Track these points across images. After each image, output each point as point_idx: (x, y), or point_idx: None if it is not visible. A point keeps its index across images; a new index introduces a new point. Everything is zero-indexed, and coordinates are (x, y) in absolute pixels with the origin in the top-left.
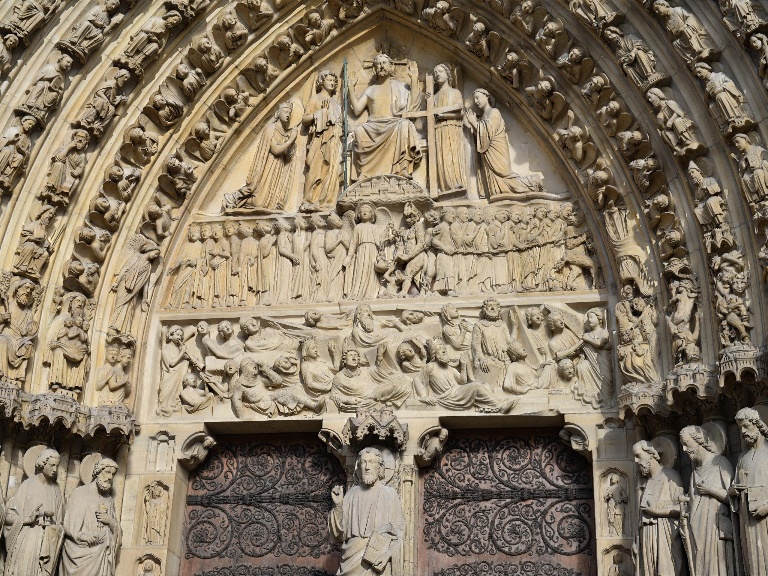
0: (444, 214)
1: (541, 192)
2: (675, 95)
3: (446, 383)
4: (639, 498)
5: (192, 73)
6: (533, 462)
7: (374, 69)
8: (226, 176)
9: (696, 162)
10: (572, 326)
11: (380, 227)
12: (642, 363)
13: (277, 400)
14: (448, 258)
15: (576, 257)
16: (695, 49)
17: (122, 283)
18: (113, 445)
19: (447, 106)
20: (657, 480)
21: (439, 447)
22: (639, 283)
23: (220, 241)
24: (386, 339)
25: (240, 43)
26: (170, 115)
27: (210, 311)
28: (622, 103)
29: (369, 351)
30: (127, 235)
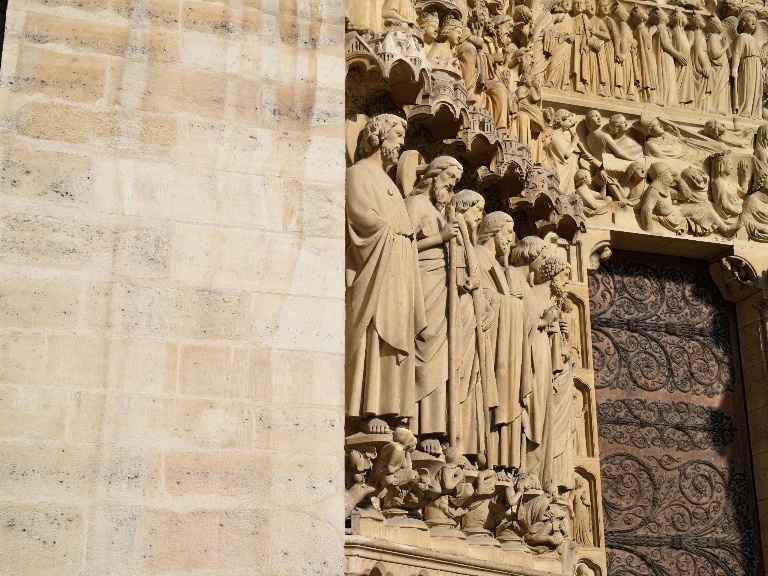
0: None
1: None
2: None
3: None
4: None
5: None
6: None
7: None
8: None
9: None
10: None
11: None
12: None
13: (691, 216)
14: None
15: None
16: None
17: (538, 45)
18: None
19: None
20: None
21: None
22: None
23: (595, 19)
24: None
25: None
26: None
27: (599, 100)
28: None
29: None
30: None
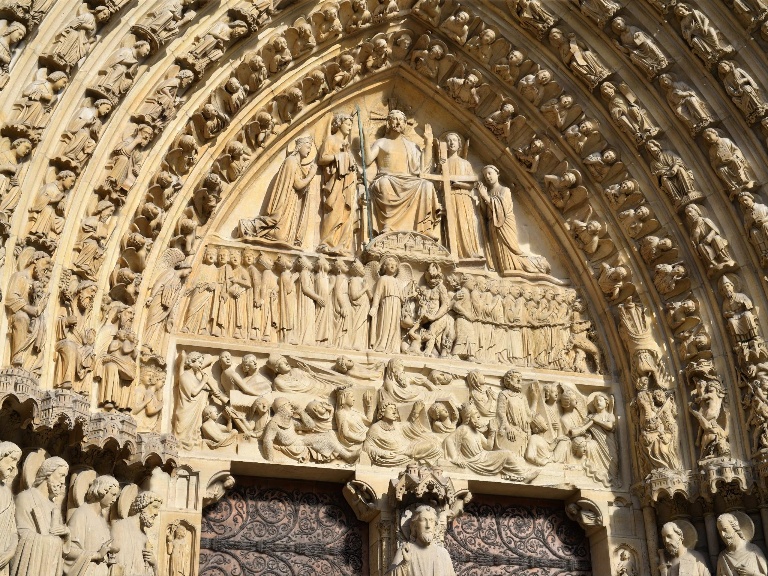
0: (465, 280)
1: (549, 275)
2: (708, 214)
3: (477, 447)
4: (666, 575)
5: (241, 89)
6: (537, 531)
7: (388, 123)
8: (239, 200)
9: (726, 277)
10: (579, 406)
11: (400, 282)
12: (668, 451)
13: (311, 446)
14: (470, 324)
15: (584, 342)
16: (742, 179)
17: (157, 298)
18: (138, 476)
19: (463, 175)
20: (688, 560)
21: (462, 510)
22: (657, 376)
23: (239, 268)
24: (419, 396)
25: (283, 68)
26: (215, 127)
27: (233, 342)
28: (652, 210)
29: (403, 406)
30: (161, 247)
